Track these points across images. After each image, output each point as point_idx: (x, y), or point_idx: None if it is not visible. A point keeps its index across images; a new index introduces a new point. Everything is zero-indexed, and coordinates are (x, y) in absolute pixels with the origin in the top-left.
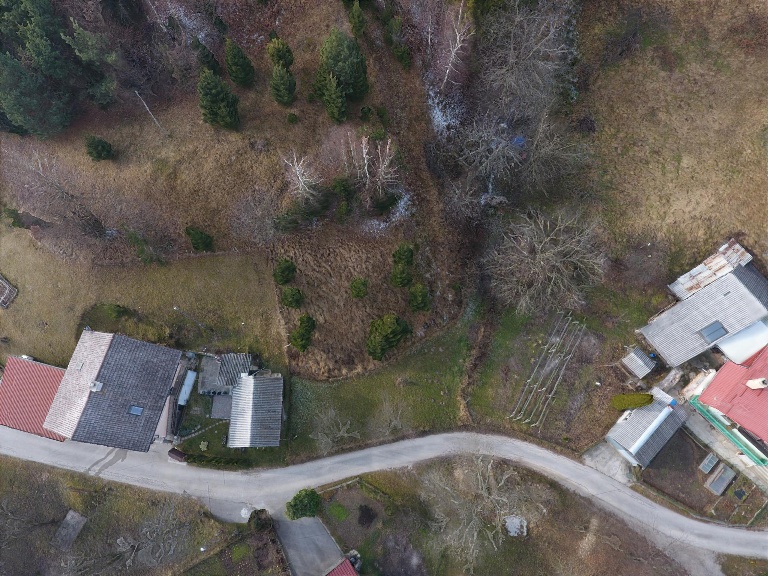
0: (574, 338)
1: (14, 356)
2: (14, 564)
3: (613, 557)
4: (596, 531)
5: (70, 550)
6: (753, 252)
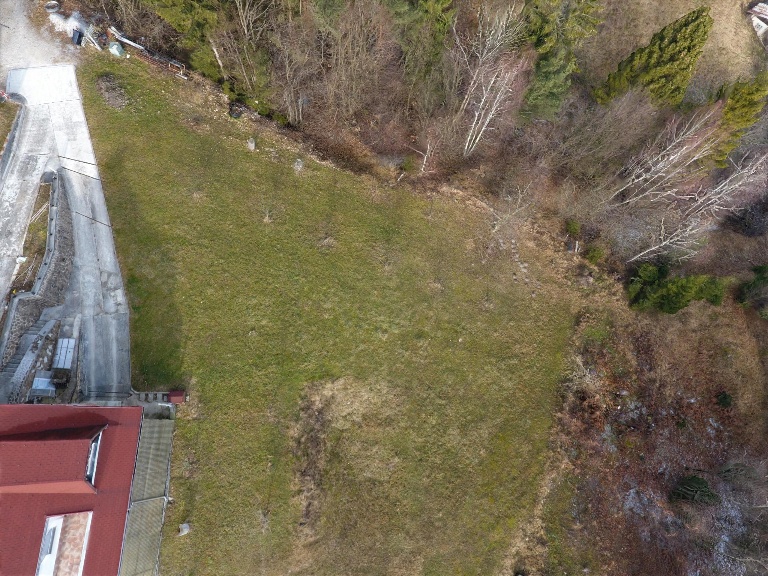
0: None
1: None
2: None
3: None
4: None
5: None
6: (751, 2)
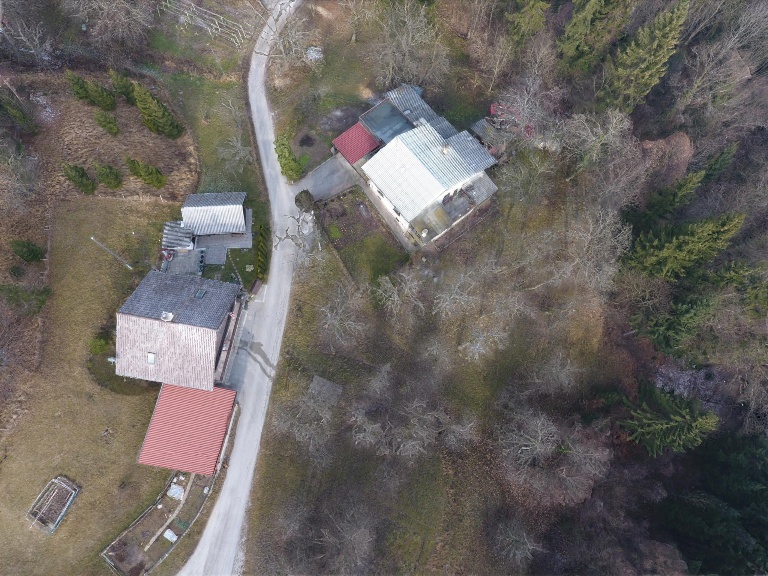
0: (182, 8)
1: (139, 456)
2: (357, 444)
3: (332, 0)
4: (316, 6)
5: (341, 385)
6: None
